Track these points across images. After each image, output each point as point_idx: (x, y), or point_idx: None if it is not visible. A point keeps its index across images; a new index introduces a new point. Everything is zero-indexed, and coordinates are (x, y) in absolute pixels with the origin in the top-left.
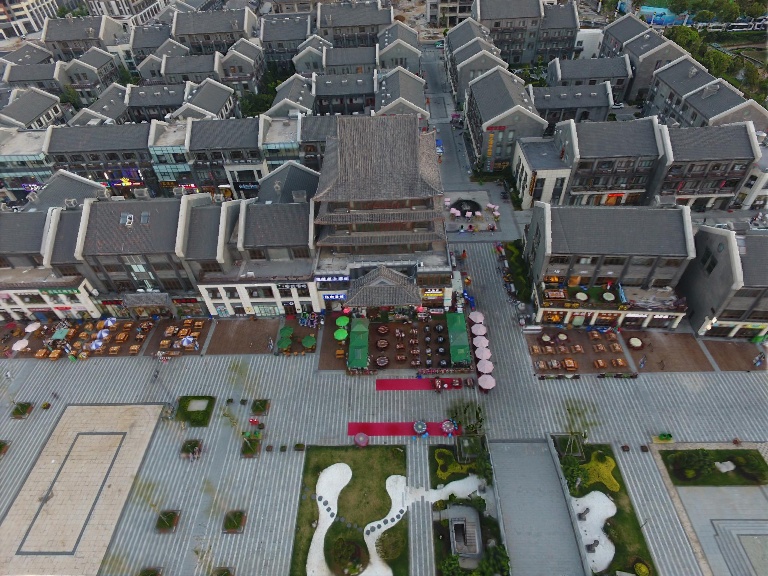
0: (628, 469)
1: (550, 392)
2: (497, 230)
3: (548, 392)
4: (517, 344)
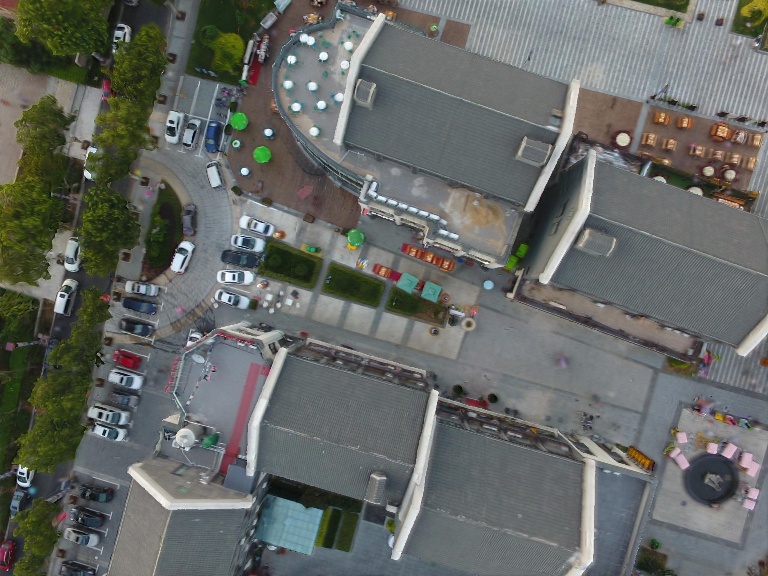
0: (729, 3)
1: (760, 106)
2: (686, 406)
3: (762, 106)
4: (764, 181)
